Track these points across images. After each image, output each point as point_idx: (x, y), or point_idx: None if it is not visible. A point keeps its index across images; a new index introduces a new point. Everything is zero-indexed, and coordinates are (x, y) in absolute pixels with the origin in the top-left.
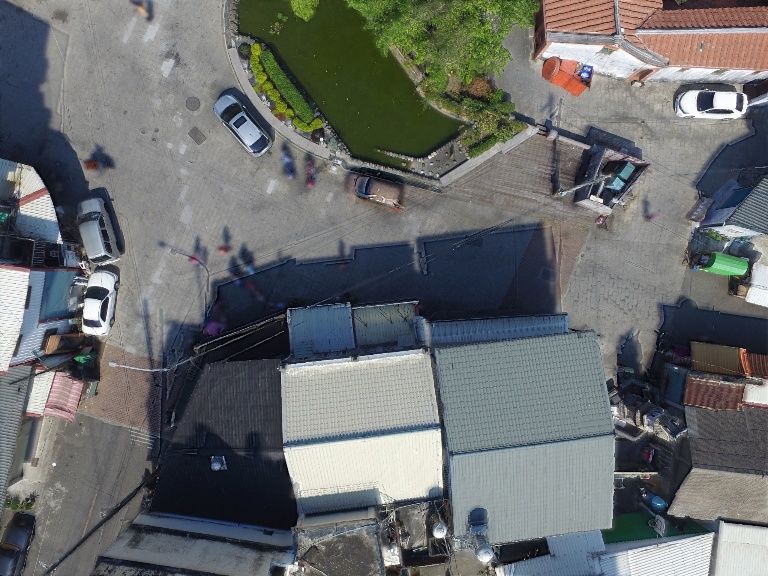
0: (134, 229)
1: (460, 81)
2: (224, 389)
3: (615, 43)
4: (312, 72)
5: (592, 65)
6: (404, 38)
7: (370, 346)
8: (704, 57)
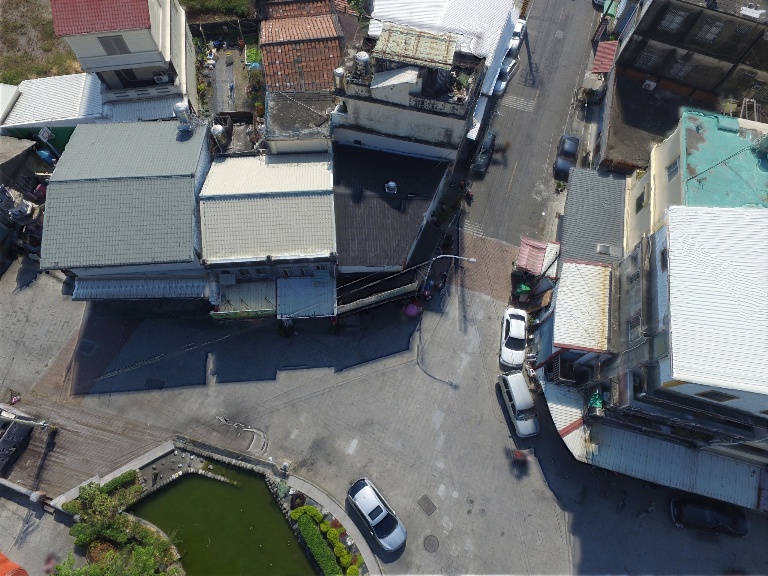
0: (488, 407)
1: None
2: (387, 244)
3: None
4: None
5: None
6: None
7: (264, 280)
8: None
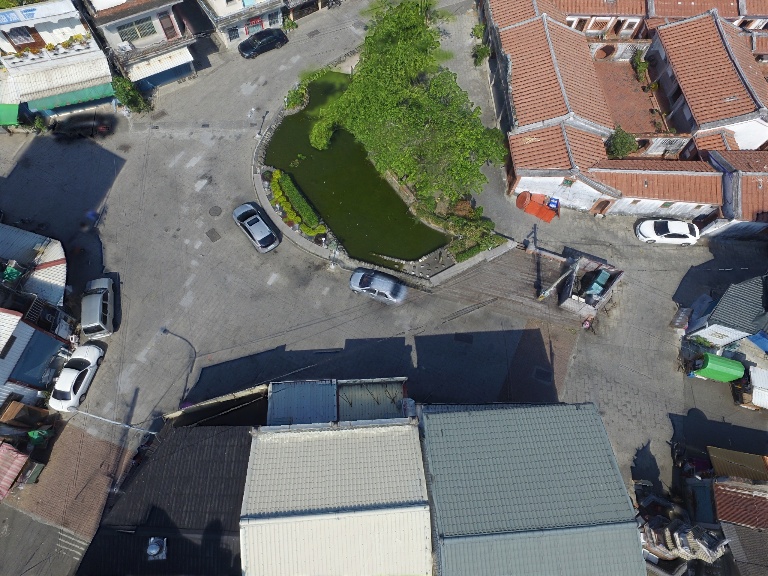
0: (134, 309)
1: (446, 206)
2: (185, 456)
3: (572, 175)
4: (321, 194)
5: (558, 198)
6: (398, 164)
7: None
8: (650, 191)
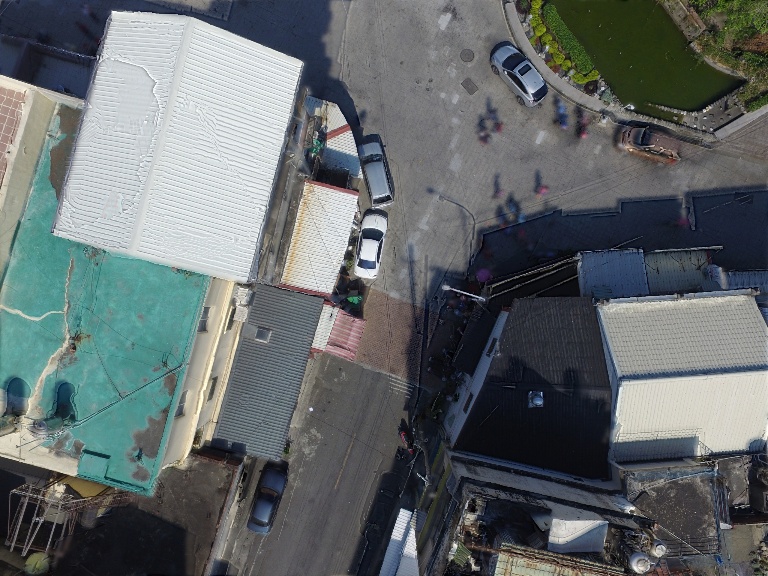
0: (404, 175)
1: (732, 38)
2: (536, 324)
3: None
4: (584, 27)
5: None
6: None
7: (664, 293)
8: None
